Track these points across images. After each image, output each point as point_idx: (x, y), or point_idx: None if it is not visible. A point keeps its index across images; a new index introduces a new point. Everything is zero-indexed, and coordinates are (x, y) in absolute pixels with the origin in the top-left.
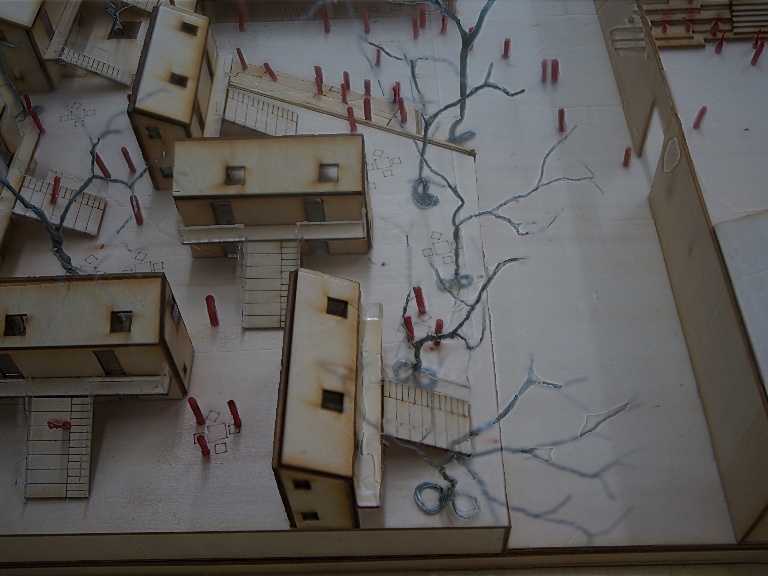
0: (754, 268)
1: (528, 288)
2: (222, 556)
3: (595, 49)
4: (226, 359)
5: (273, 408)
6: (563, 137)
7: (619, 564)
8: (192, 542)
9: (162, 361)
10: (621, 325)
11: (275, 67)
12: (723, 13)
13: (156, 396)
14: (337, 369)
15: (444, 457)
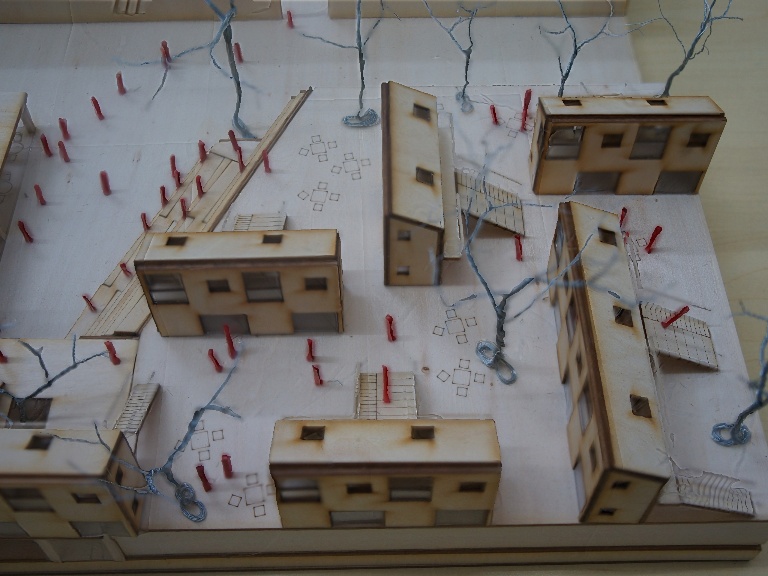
0: None
1: None
2: None
3: (128, 30)
4: None
5: None
6: None
7: None
8: None
9: None
10: (463, 47)
11: (86, 289)
12: None
13: None
14: None
15: None
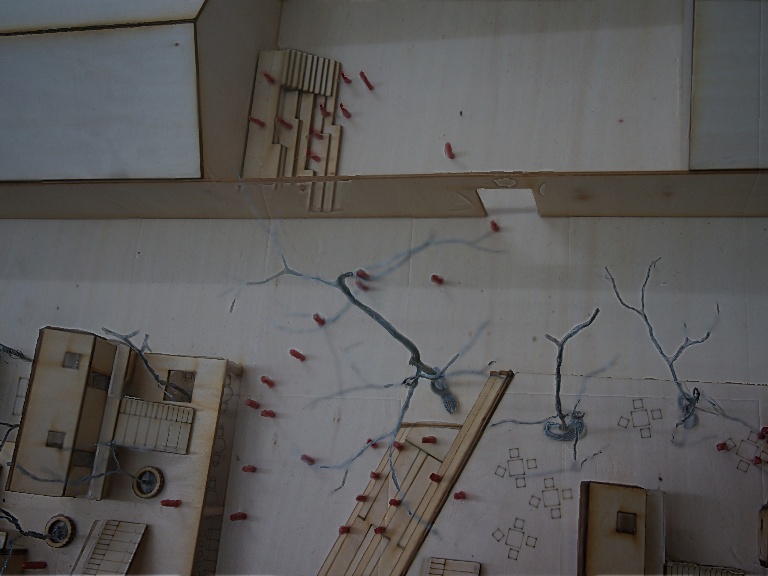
0: (752, 148)
1: (649, 344)
2: None
3: (325, 230)
4: None
5: None
6: None
7: None
8: None
9: None
10: (697, 268)
11: None
12: (306, 100)
13: None
14: None
15: None
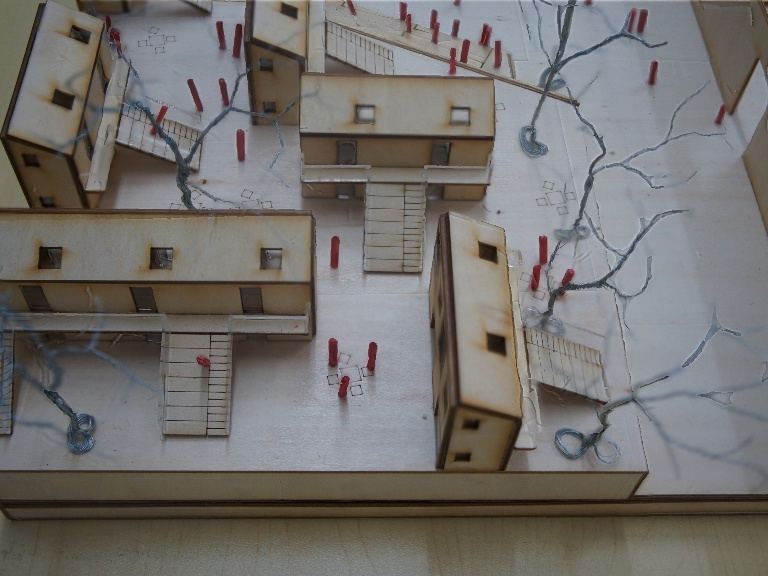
0: None
1: None
2: (354, 498)
3: (678, 0)
4: (350, 302)
5: (404, 352)
6: (696, 92)
7: (731, 513)
8: (332, 482)
9: (306, 300)
10: (725, 282)
11: None
12: None
13: (286, 337)
14: (496, 313)
15: (580, 404)
